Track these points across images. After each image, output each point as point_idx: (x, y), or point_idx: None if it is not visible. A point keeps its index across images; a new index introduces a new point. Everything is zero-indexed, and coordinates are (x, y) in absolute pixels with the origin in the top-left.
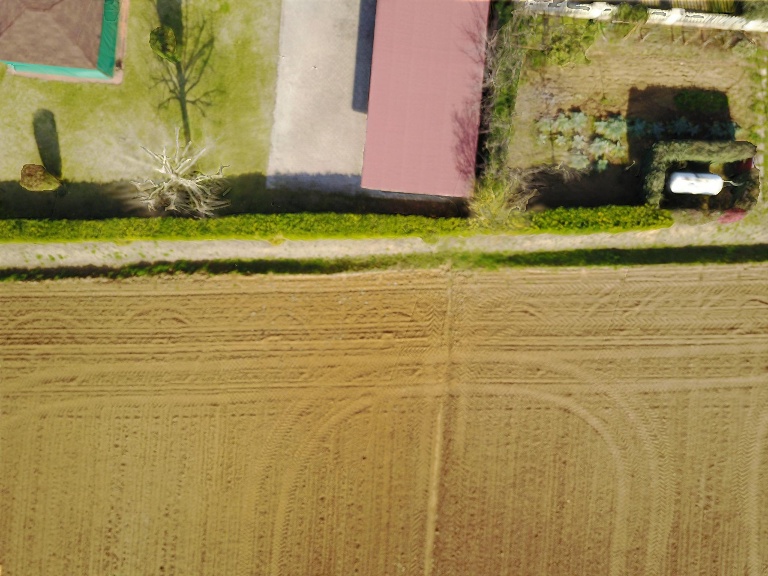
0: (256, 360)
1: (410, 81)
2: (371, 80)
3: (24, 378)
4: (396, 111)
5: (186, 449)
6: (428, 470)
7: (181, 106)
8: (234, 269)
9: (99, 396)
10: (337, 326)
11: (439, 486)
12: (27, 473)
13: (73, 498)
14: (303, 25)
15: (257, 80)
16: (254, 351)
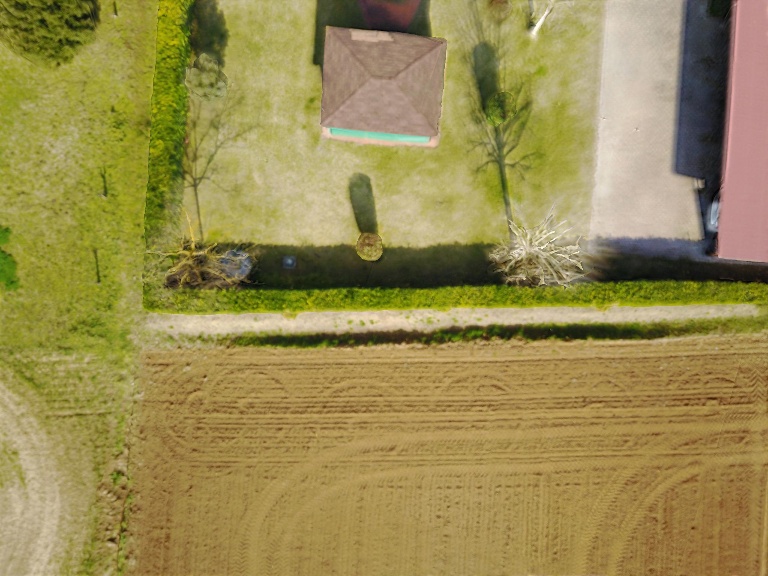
0: (578, 428)
1: (766, 148)
2: (728, 148)
3: (341, 447)
4: (752, 179)
5: (509, 520)
6: (758, 540)
7: (500, 169)
8: (551, 334)
9: (420, 466)
10: (660, 392)
11: (767, 556)
12: (347, 545)
13: (395, 570)
14: (624, 86)
15: (577, 142)
16: (576, 418)
